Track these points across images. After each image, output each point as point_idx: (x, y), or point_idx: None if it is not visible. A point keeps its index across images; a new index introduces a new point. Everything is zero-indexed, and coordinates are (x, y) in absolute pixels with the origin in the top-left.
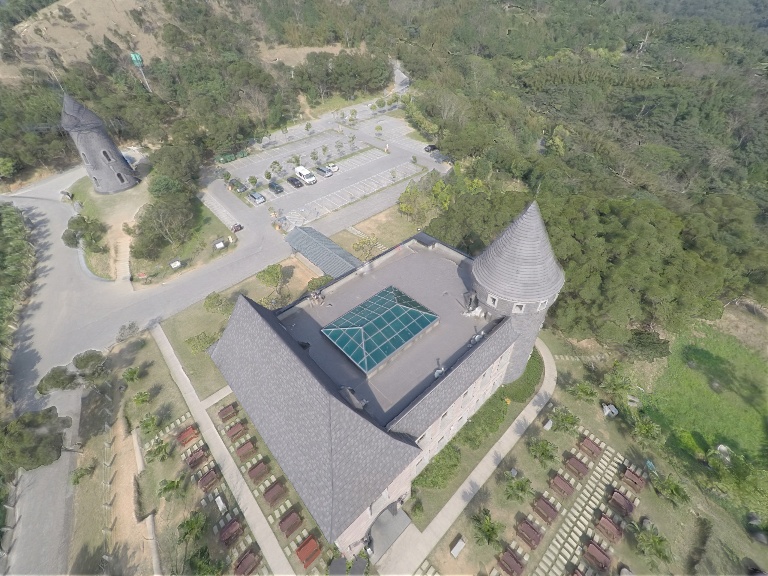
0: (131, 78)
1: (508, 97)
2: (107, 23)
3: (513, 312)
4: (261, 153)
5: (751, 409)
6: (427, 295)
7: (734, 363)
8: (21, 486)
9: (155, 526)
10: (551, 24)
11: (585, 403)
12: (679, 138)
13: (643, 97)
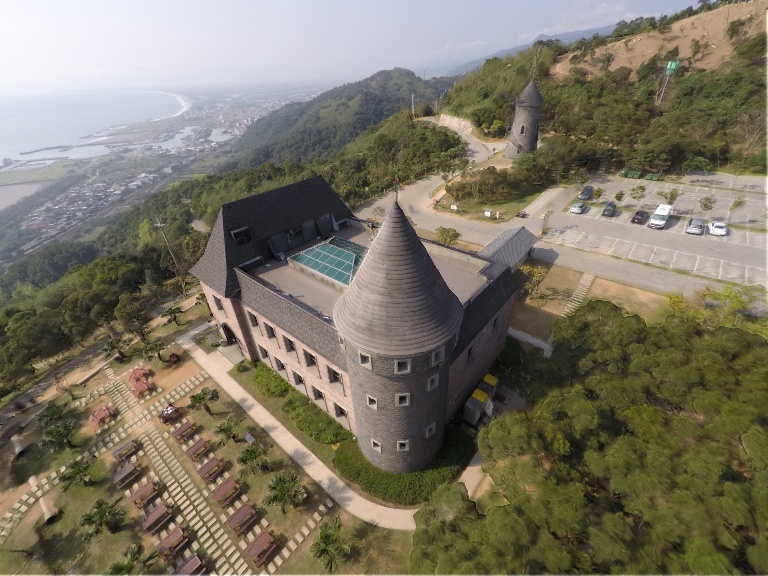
0: (655, 86)
1: None
2: (699, 34)
3: None
4: (676, 184)
5: None
6: None
7: None
8: None
9: None
10: None
11: None
12: None
13: None
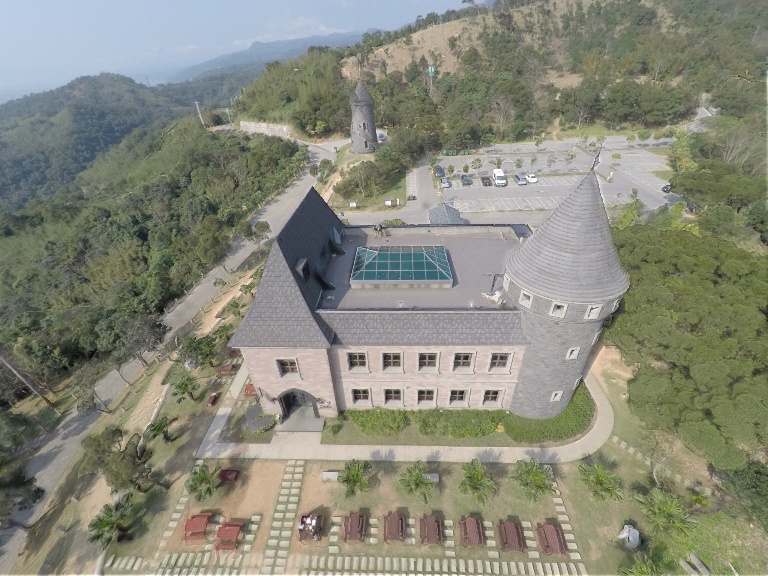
0: (423, 85)
1: None
2: (431, 46)
3: (520, 302)
4: (480, 155)
5: None
6: (469, 268)
7: None
8: (205, 279)
9: (218, 324)
10: None
11: (602, 504)
12: None
13: None
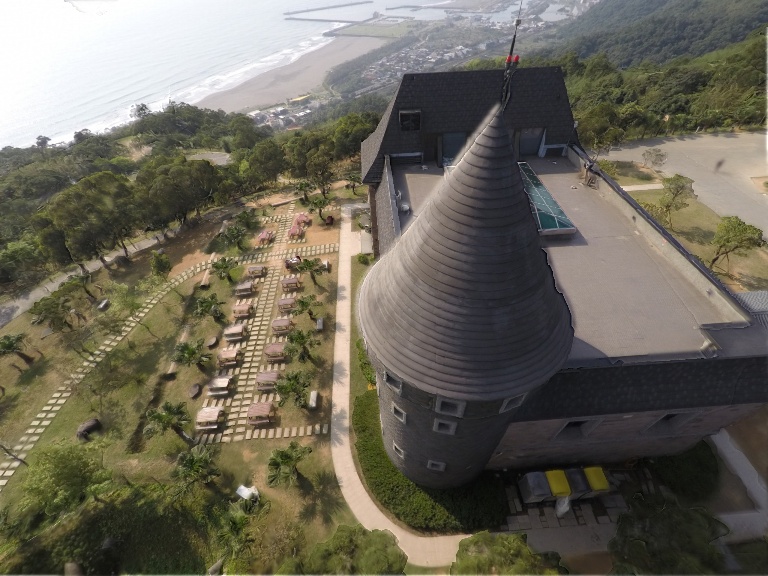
0: None
1: None
2: None
3: None
4: None
5: None
6: None
7: None
8: None
9: None
10: None
11: None
12: None
13: None
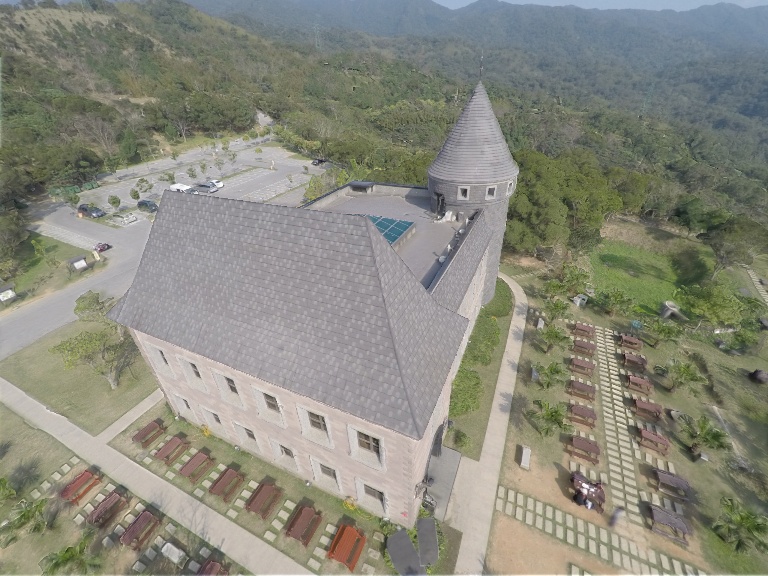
0: None
1: (370, 131)
2: None
3: (486, 199)
4: (117, 183)
5: (663, 281)
6: None
7: (633, 257)
8: None
9: None
10: (385, 83)
11: None
12: None
13: None
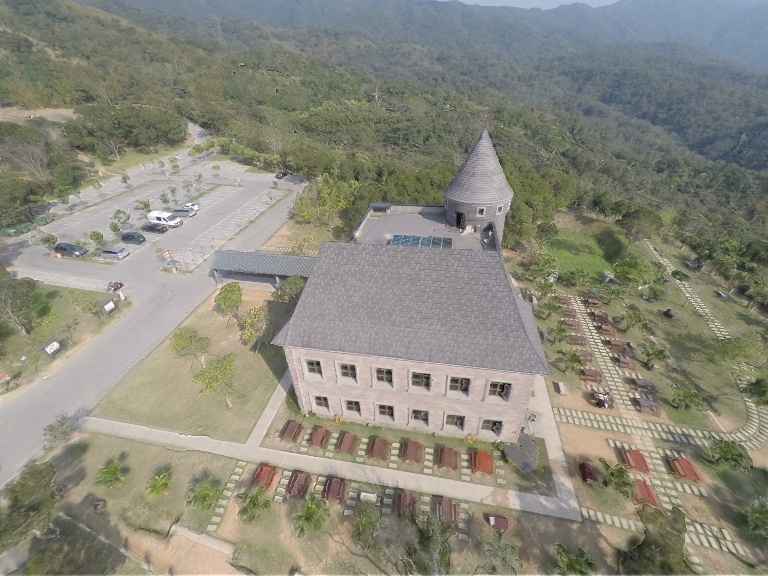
0: None
1: (309, 136)
2: None
3: (497, 215)
4: (72, 215)
5: (595, 255)
6: (423, 235)
7: (571, 239)
8: None
9: None
10: (307, 84)
11: None
12: (431, 153)
13: (398, 129)
